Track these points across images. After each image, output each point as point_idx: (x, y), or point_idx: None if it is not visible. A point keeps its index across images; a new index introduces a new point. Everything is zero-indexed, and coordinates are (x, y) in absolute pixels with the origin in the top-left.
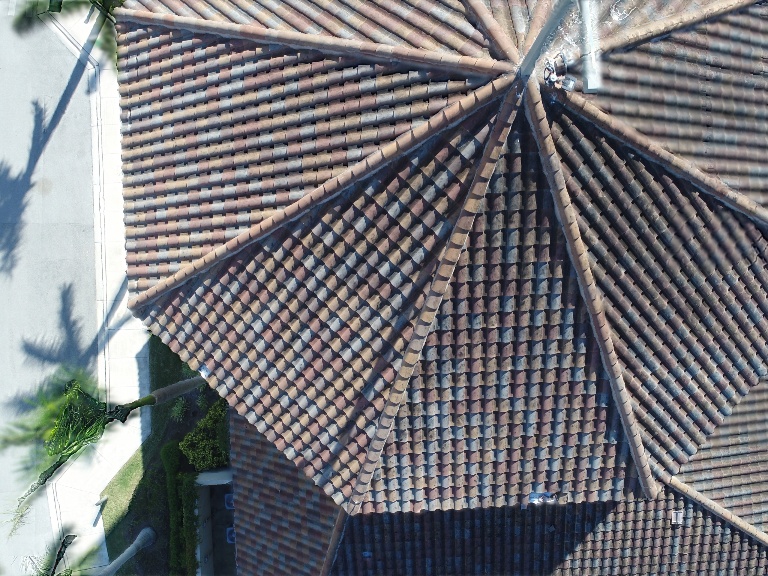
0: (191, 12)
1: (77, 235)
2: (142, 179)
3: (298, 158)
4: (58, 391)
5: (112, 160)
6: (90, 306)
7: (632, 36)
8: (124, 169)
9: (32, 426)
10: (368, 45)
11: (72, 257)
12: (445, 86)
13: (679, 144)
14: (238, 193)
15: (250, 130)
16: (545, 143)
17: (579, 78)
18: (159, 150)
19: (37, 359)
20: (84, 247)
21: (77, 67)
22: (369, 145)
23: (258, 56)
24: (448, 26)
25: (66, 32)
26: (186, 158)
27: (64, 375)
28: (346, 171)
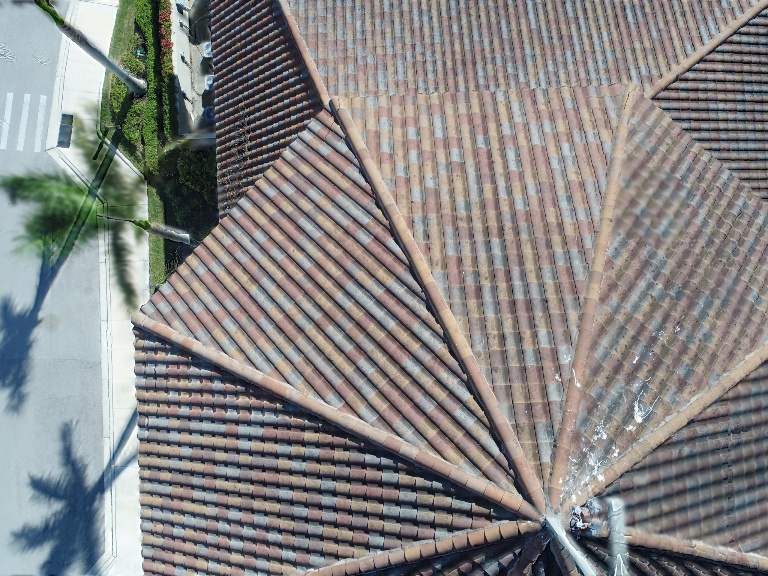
0: (210, 339)
1: (84, 372)
2: (159, 491)
3: (319, 525)
4: (64, 528)
5: (120, 297)
6: (97, 443)
7: (656, 445)
8: (141, 476)
9: (38, 563)
10: (391, 443)
11: (79, 394)
12: (470, 507)
13: (701, 529)
14: (257, 539)
15: (270, 482)
16: (570, 575)
17: (604, 505)
18: (177, 468)
19: (43, 496)
20: (91, 384)
21: (85, 203)
22: (392, 539)
23: (279, 411)
24: (472, 440)
25: (75, 168)
26: (205, 486)
27: (70, 512)
28: (368, 559)
